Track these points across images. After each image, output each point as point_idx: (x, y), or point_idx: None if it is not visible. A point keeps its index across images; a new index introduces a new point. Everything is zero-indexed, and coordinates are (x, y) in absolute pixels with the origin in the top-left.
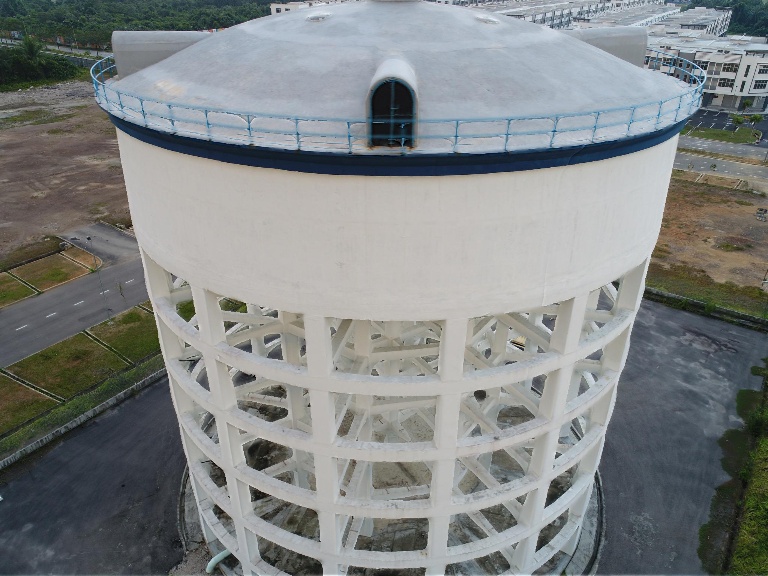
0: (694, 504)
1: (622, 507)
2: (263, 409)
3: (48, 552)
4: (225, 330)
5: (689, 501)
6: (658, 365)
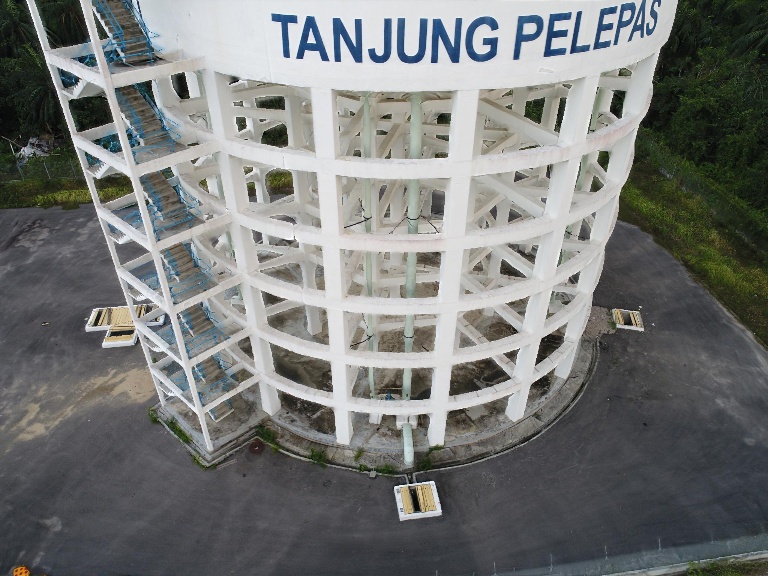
0: (273, 199)
1: None
2: (460, 409)
3: (722, 403)
4: None
5: (272, 201)
6: (101, 244)
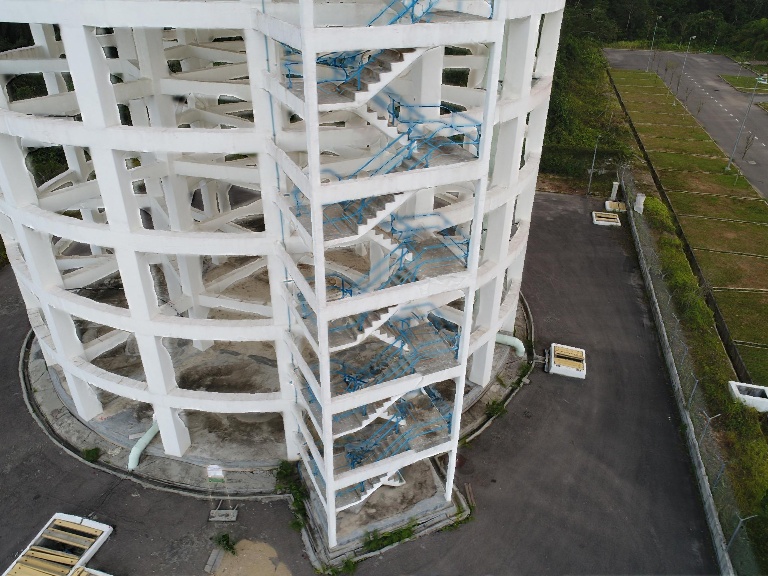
0: None
1: (20, 316)
2: None
3: None
4: (721, 434)
5: None
6: None
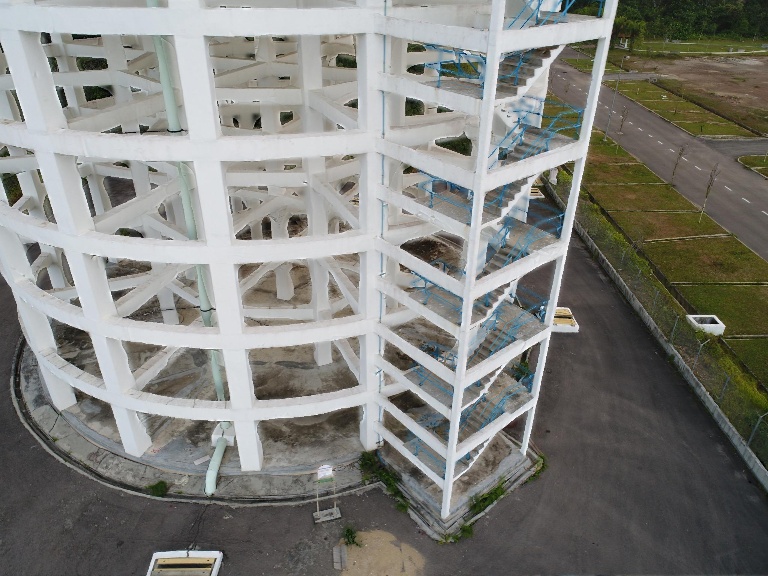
0: None
1: None
2: None
3: None
4: None
5: None
6: None
